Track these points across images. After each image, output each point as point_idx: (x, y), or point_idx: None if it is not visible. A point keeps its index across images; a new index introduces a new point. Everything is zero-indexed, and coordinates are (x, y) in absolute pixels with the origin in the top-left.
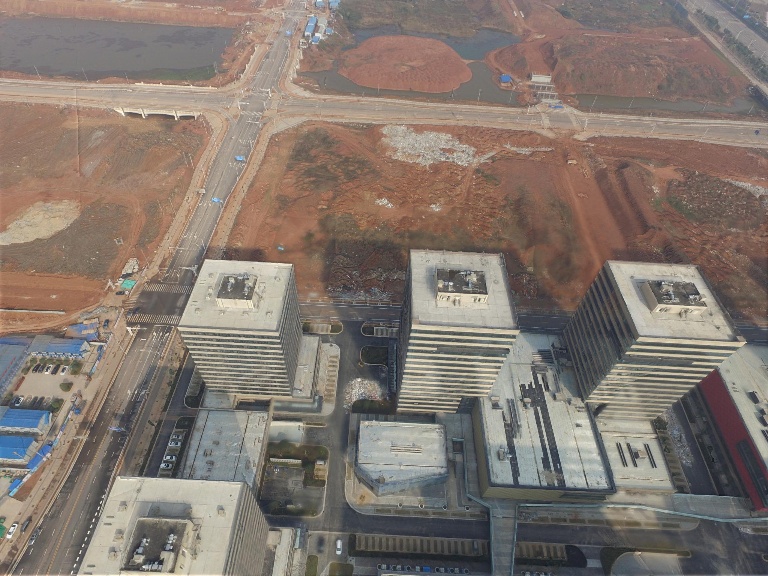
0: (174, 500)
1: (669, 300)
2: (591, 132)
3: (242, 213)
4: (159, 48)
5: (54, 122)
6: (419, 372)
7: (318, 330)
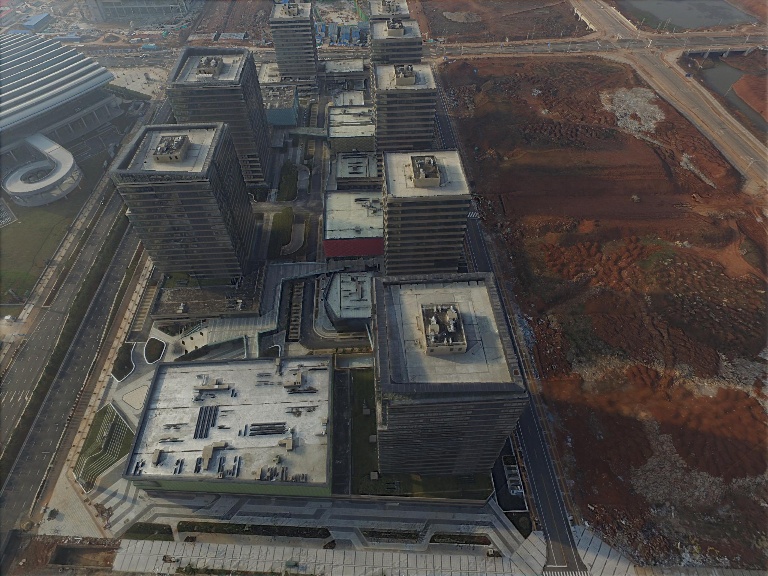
0: (305, 11)
1: None
2: None
3: None
4: (682, 7)
5: None
6: None
7: None
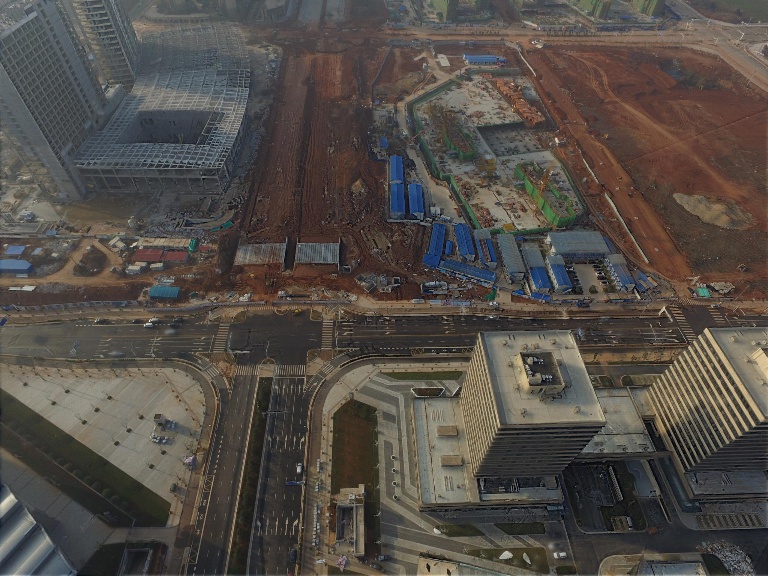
0: (571, 373)
1: None
2: None
3: None
4: None
5: None
6: None
7: None
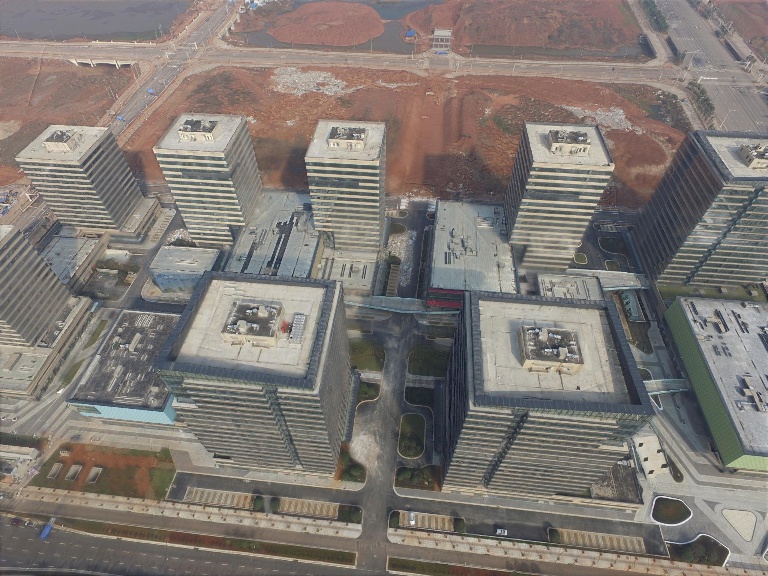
0: None
1: (338, 137)
2: (462, 72)
3: (140, 128)
4: (124, 17)
5: (21, 70)
6: (184, 199)
7: (165, 201)
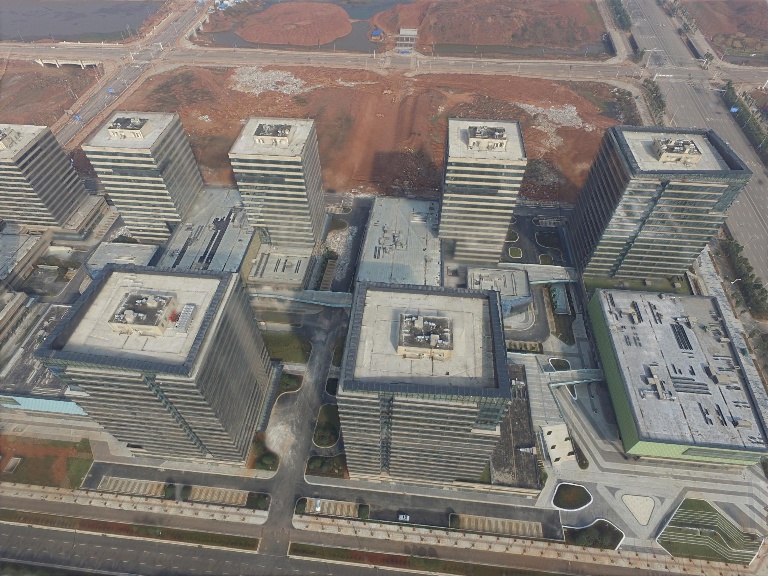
0: None
1: (263, 133)
2: (422, 70)
3: None
4: (95, 18)
5: None
6: (119, 195)
7: None
